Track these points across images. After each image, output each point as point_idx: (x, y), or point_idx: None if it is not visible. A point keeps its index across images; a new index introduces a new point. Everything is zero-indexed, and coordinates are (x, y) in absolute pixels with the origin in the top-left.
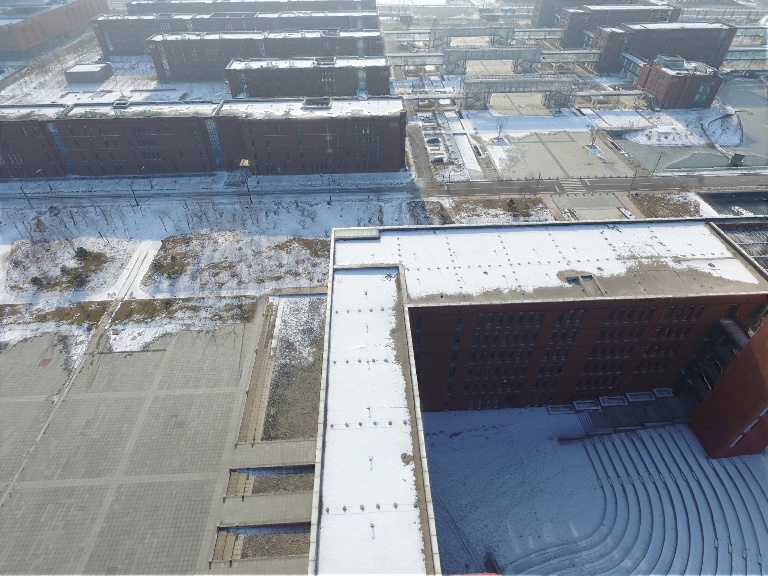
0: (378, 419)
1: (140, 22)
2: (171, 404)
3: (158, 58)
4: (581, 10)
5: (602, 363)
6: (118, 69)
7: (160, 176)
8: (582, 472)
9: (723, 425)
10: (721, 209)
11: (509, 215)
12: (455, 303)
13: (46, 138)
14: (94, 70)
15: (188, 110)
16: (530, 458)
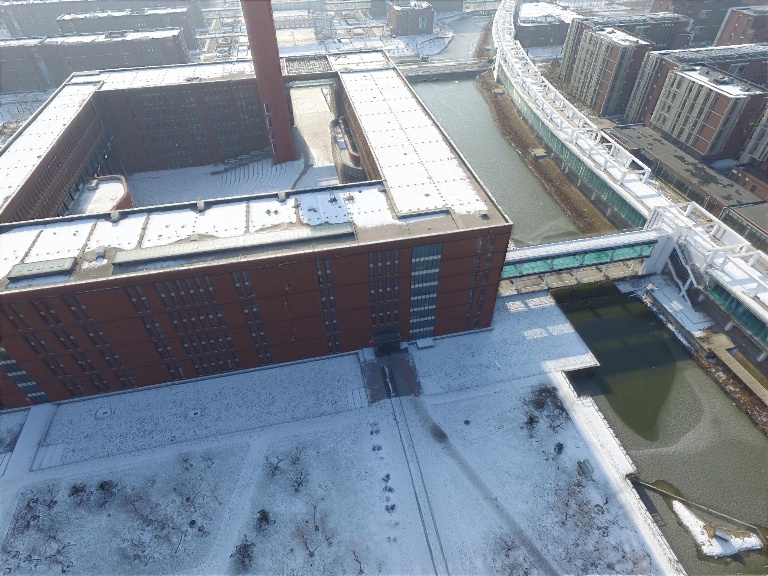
0: None
1: None
2: None
3: (9, 20)
4: None
5: (223, 129)
6: None
7: (5, 94)
8: (215, 182)
9: None
10: None
11: None
12: (120, 88)
13: None
14: None
15: (19, 43)
16: (191, 181)
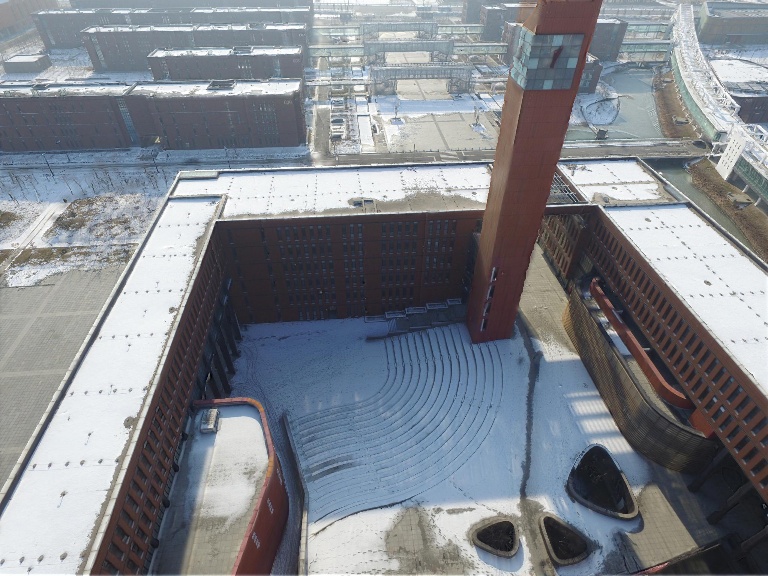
0: (162, 288)
1: (80, 16)
2: (51, 323)
3: (92, 49)
4: (498, 7)
5: (395, 274)
6: (57, 60)
7: (79, 151)
8: (377, 360)
9: (475, 314)
10: None
11: None
12: (254, 218)
13: None
14: (31, 60)
15: (102, 91)
16: (339, 352)
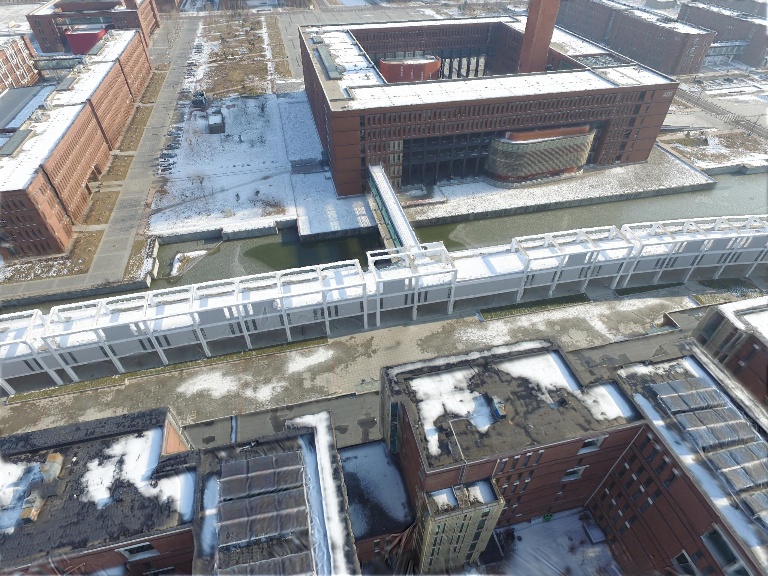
0: None
1: None
2: None
3: (694, 1)
4: None
5: None
6: None
7: (583, 36)
8: None
9: None
10: None
11: None
12: None
13: (566, 3)
14: (661, 1)
15: (617, 6)
16: None
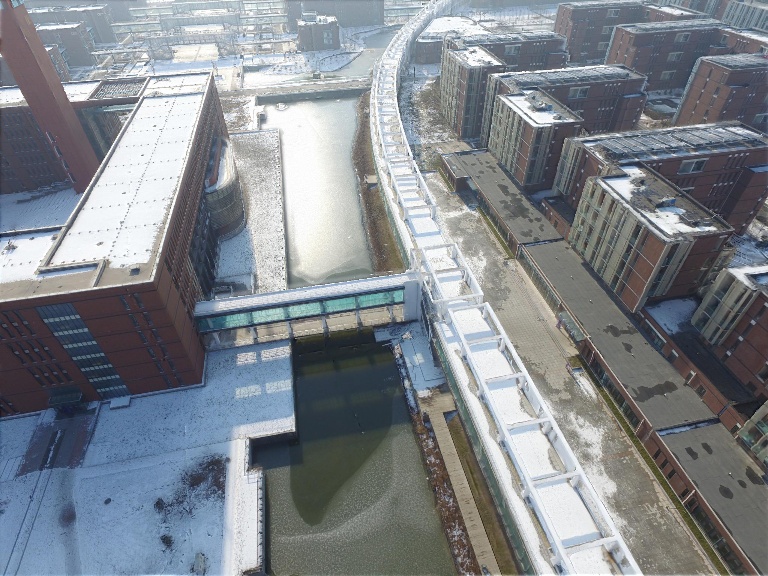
0: None
1: None
2: None
3: None
4: None
5: (28, 156)
6: None
7: None
8: None
9: None
10: (269, 105)
11: None
12: None
13: None
14: None
15: None
16: None
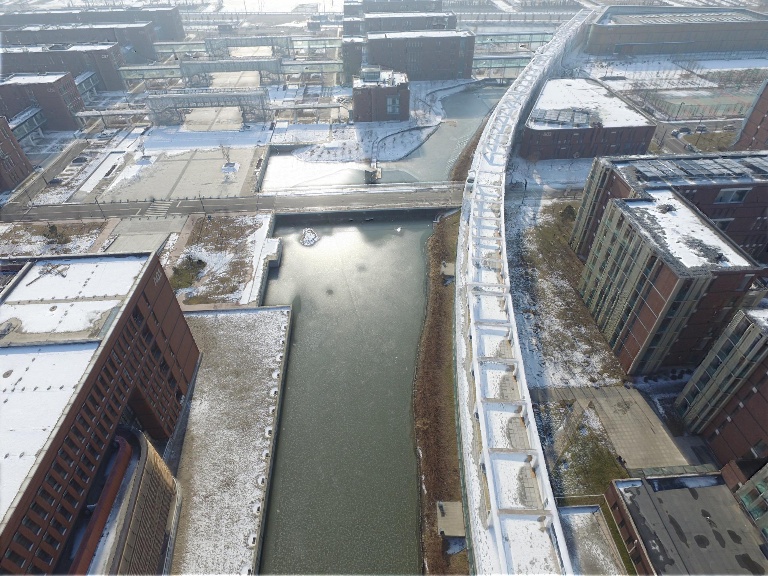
0: None
1: None
2: None
3: None
4: (360, 18)
5: None
6: None
7: None
8: None
9: None
10: (291, 231)
11: (45, 242)
12: None
13: None
14: None
15: None
16: None
